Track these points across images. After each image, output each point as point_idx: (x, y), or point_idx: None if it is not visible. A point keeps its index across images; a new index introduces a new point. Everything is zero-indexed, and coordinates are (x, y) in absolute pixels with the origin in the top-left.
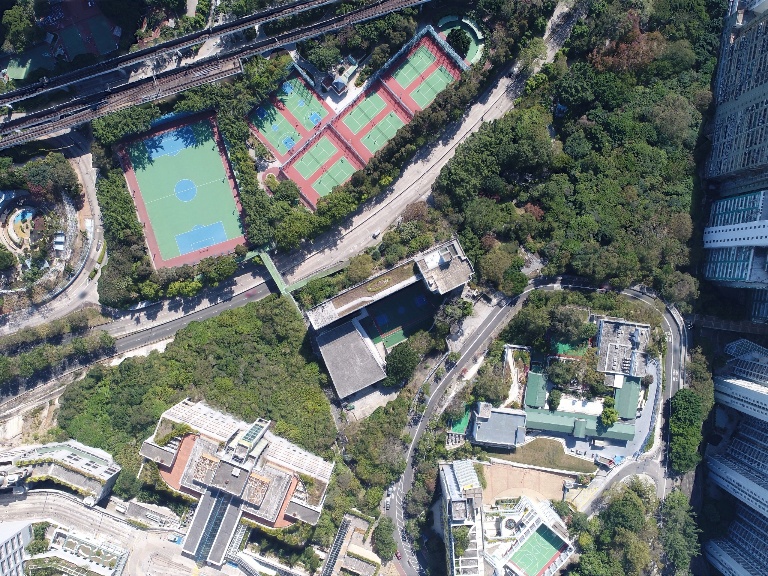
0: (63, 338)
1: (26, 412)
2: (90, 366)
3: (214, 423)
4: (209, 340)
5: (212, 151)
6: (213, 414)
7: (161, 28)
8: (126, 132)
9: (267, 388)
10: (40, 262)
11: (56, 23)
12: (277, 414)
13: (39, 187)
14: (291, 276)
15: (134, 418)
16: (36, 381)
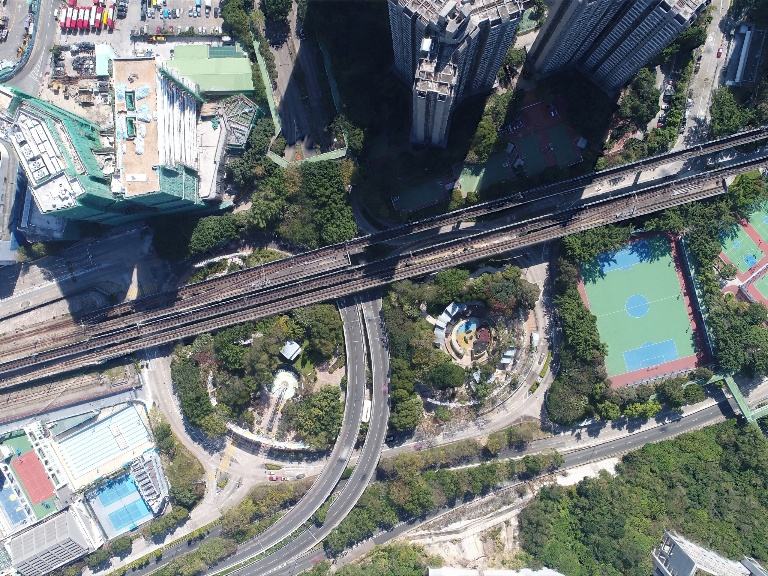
0: (499, 451)
1: (481, 531)
2: (531, 482)
3: (725, 568)
4: (675, 467)
5: (668, 267)
6: (705, 553)
7: (629, 141)
8: (602, 251)
9: (747, 523)
10: (488, 376)
11: (515, 132)
12: (764, 553)
13: (501, 303)
14: (745, 398)
15: (631, 556)
16: (473, 494)
